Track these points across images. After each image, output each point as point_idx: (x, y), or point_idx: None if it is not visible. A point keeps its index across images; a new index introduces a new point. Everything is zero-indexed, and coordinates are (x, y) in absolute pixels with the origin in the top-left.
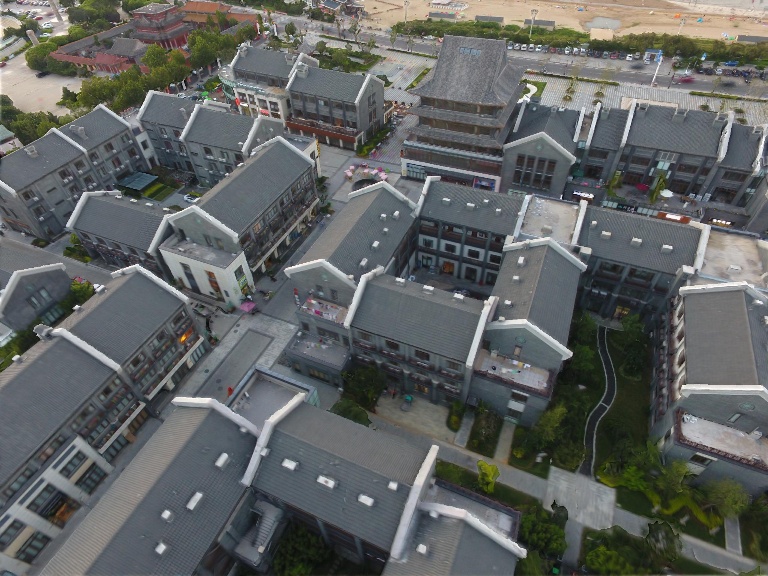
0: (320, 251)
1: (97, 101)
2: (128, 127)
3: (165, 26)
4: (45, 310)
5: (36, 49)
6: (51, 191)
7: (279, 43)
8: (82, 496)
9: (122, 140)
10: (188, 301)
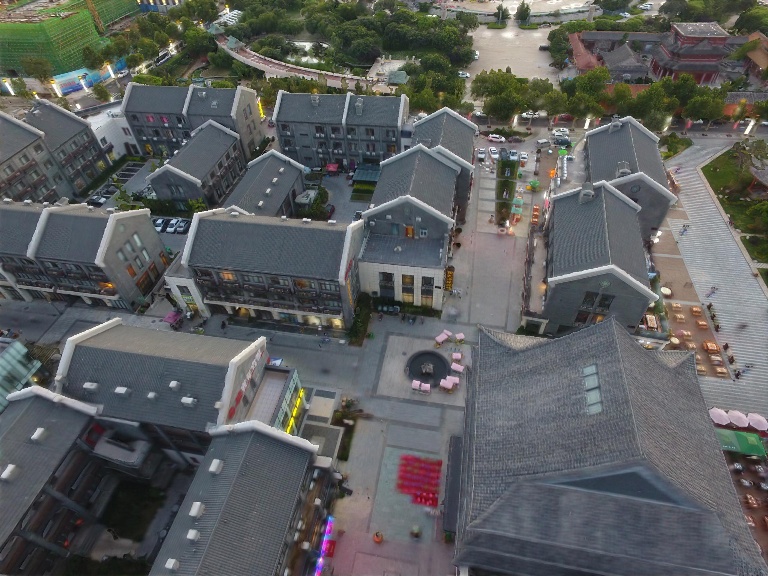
0: (126, 337)
1: (479, 92)
2: (398, 126)
3: (683, 54)
4: (178, 199)
5: (572, 24)
6: (304, 135)
7: (765, 146)
8: (6, 295)
9: (387, 133)
10: (99, 265)
